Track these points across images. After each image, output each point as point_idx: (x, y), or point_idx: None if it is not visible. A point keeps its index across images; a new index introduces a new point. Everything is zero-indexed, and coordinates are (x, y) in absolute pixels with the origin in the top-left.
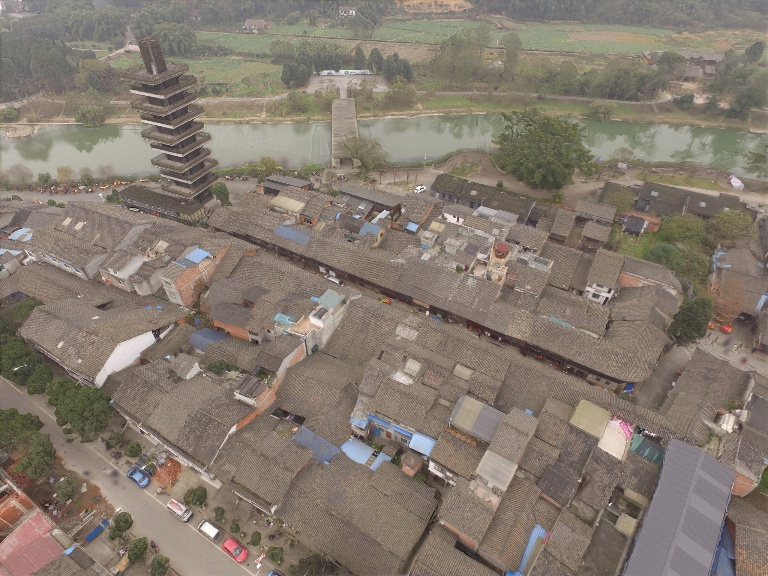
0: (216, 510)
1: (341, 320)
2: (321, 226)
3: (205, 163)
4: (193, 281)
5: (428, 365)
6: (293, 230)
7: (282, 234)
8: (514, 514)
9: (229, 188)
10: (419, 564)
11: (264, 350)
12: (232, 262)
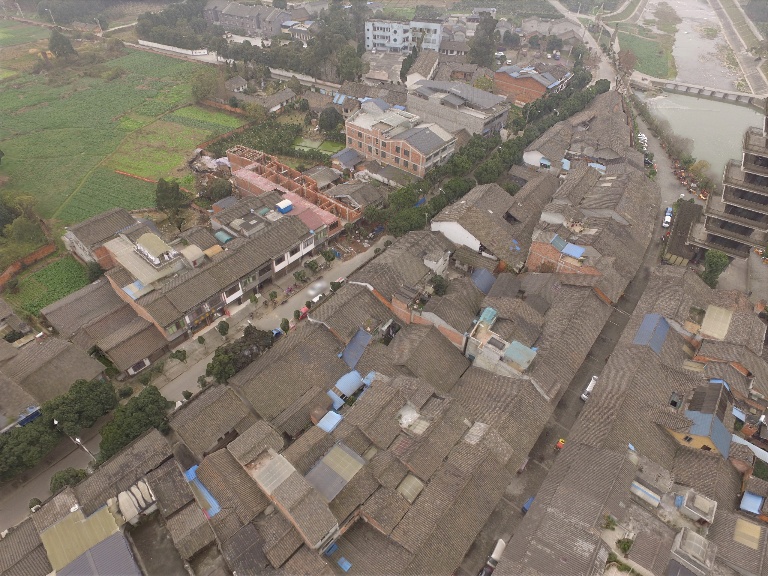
0: (323, 294)
1: (506, 376)
2: (692, 367)
3: (759, 237)
4: (547, 259)
5: (418, 441)
6: (655, 327)
7: (647, 320)
8: (234, 483)
9: (764, 287)
10: (227, 389)
11: (443, 298)
12: (581, 281)
